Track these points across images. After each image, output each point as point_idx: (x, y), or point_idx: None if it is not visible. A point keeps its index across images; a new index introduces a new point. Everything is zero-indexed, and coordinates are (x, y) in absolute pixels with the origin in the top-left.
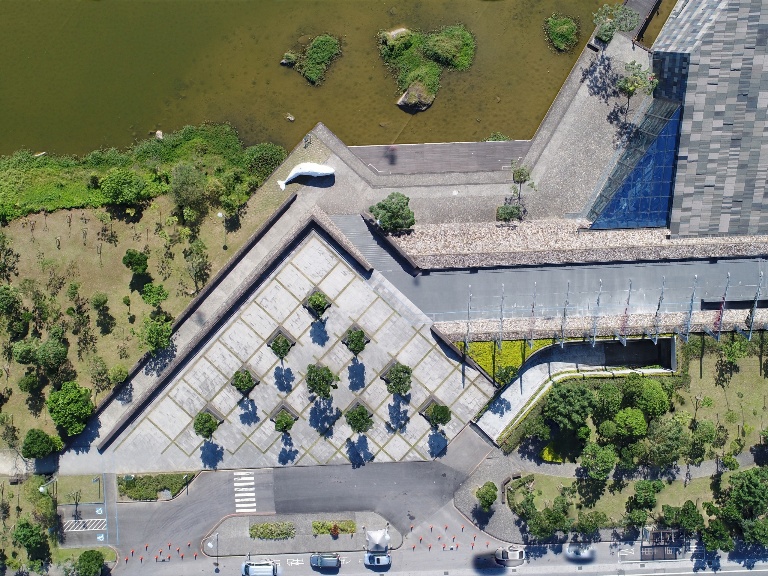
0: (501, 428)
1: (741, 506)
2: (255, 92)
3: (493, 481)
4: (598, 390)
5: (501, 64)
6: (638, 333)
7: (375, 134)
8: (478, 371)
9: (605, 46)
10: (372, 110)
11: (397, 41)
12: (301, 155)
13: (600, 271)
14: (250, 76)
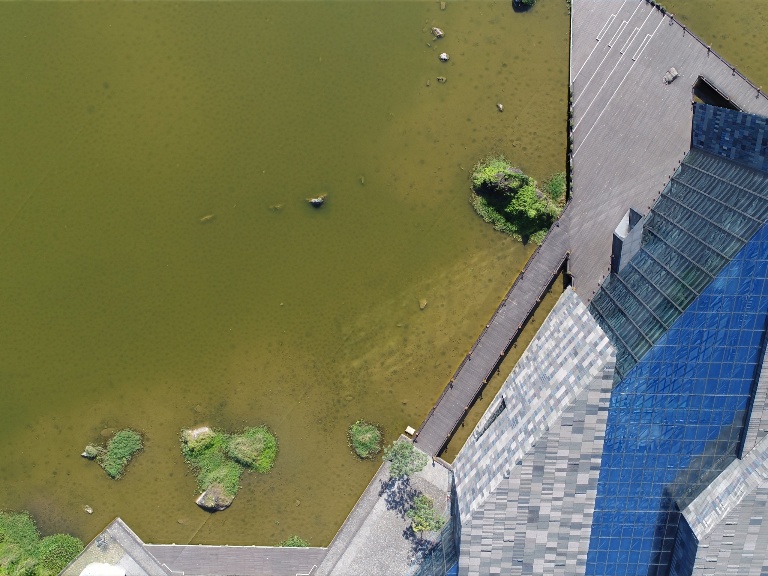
0: None
1: None
2: (55, 482)
3: None
4: None
5: (302, 468)
6: None
7: (173, 531)
8: None
9: None
10: (171, 506)
11: (197, 443)
12: (94, 553)
13: None
14: (51, 466)
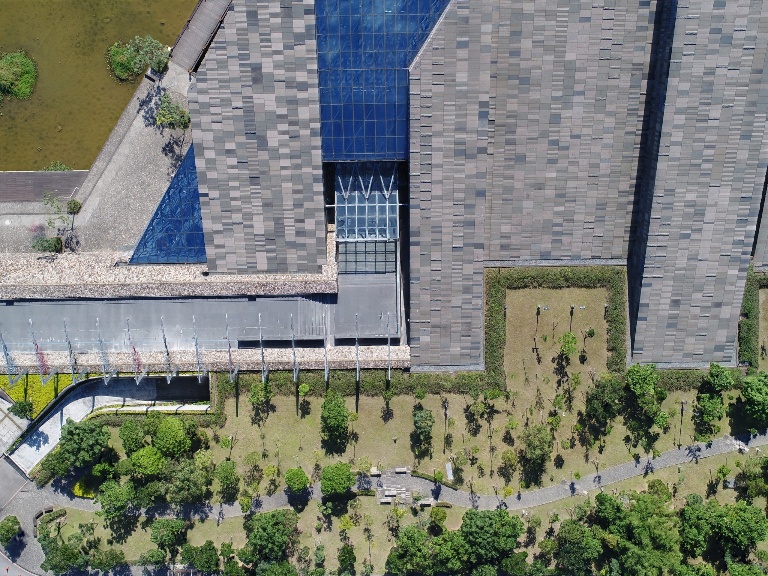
0: (36, 461)
1: (251, 549)
2: None
3: (26, 514)
4: (120, 427)
5: (62, 92)
6: (171, 370)
7: None
8: (12, 404)
9: (161, 77)
10: None
11: None
12: None
13: (137, 306)
14: None
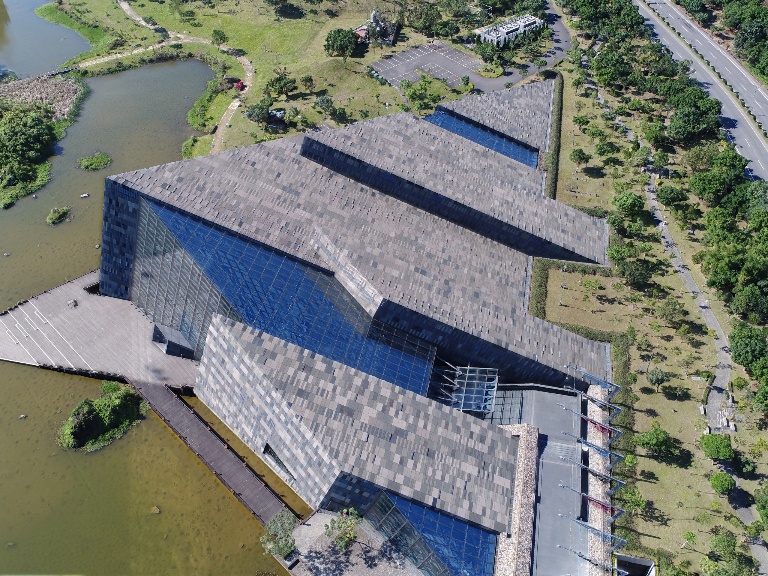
0: None
1: None
2: None
3: None
4: None
5: None
6: None
7: None
8: None
9: (297, 552)
10: None
11: None
12: None
13: None
14: None
